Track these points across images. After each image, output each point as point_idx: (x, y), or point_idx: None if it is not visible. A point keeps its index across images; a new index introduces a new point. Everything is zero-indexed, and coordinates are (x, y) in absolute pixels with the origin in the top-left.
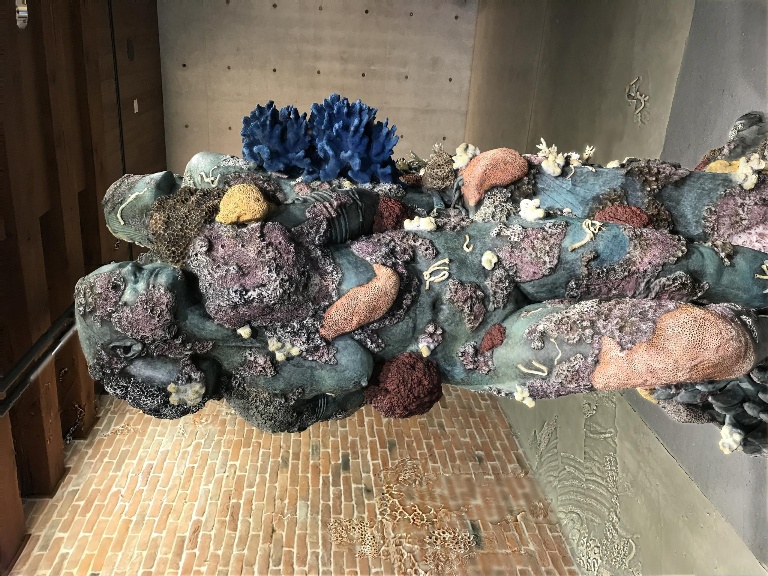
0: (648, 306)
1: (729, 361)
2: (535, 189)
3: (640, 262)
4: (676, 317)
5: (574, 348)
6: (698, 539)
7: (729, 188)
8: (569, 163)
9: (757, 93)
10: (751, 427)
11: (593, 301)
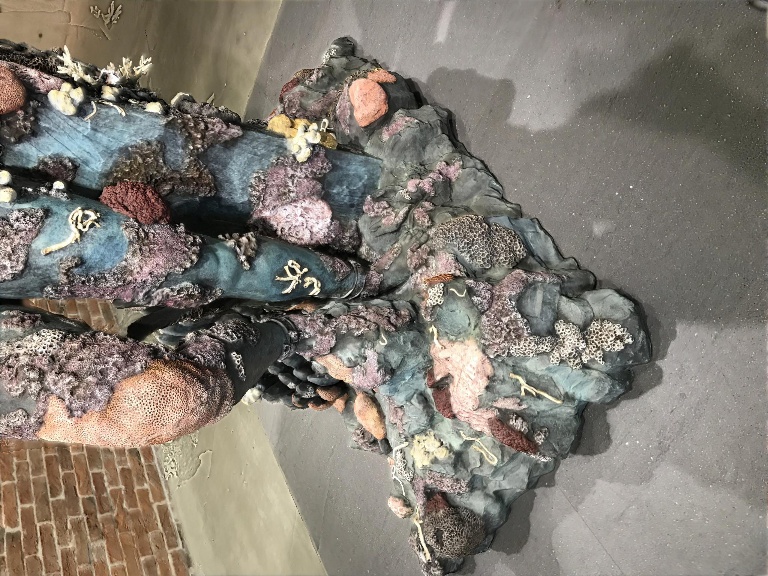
0: (112, 362)
1: (194, 427)
2: (35, 128)
3: (138, 271)
4: (138, 385)
5: (16, 401)
6: (244, 421)
7: (282, 156)
8: (101, 87)
9: (357, 18)
10: (273, 379)
11: (54, 337)
